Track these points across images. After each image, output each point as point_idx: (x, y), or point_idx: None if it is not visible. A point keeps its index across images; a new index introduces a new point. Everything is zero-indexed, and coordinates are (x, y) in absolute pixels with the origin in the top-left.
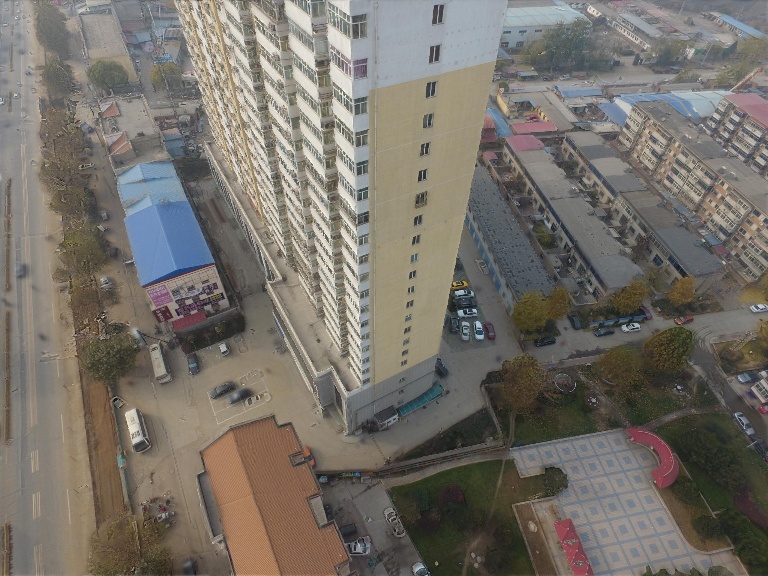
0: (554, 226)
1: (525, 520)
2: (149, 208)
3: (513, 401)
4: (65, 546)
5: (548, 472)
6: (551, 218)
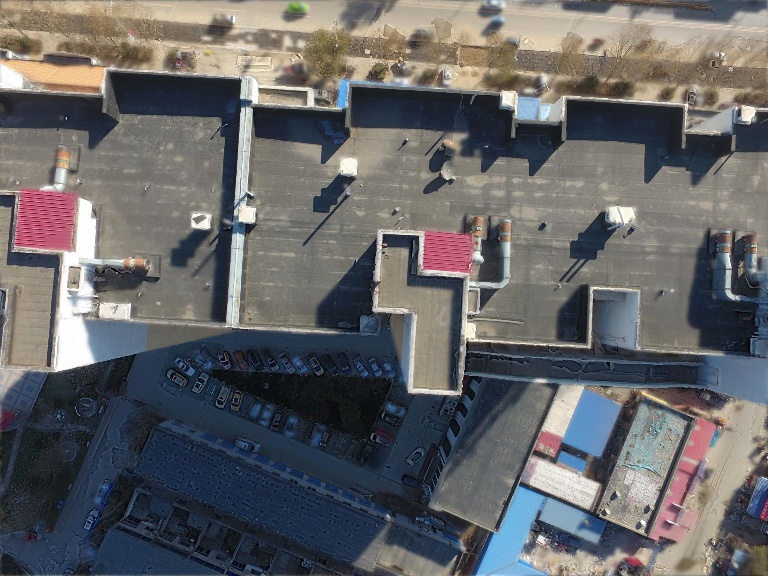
0: (239, 568)
1: None
2: None
3: None
4: (200, 4)
5: None
6: (248, 575)
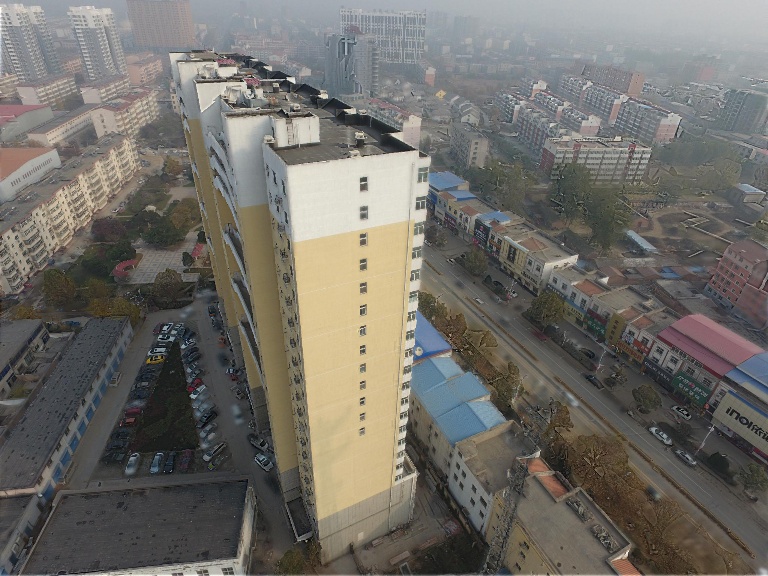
0: None
1: (209, 263)
2: (431, 349)
3: (178, 295)
4: None
5: (188, 263)
6: None
